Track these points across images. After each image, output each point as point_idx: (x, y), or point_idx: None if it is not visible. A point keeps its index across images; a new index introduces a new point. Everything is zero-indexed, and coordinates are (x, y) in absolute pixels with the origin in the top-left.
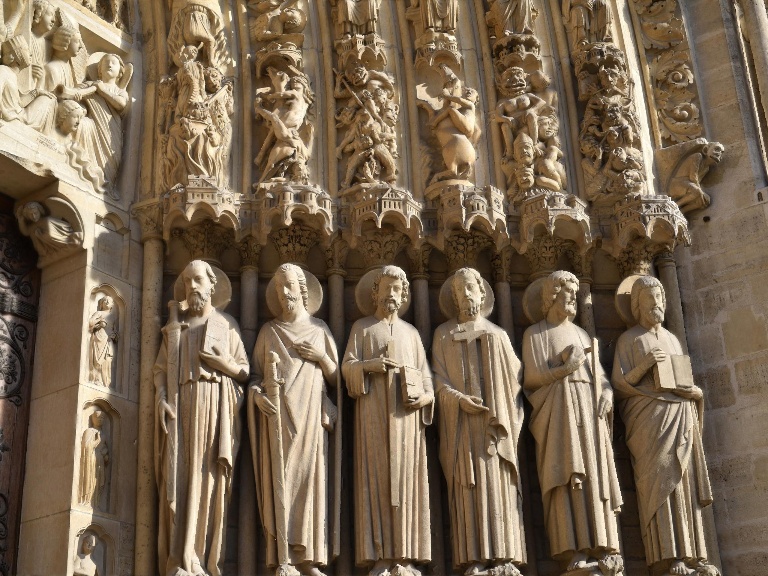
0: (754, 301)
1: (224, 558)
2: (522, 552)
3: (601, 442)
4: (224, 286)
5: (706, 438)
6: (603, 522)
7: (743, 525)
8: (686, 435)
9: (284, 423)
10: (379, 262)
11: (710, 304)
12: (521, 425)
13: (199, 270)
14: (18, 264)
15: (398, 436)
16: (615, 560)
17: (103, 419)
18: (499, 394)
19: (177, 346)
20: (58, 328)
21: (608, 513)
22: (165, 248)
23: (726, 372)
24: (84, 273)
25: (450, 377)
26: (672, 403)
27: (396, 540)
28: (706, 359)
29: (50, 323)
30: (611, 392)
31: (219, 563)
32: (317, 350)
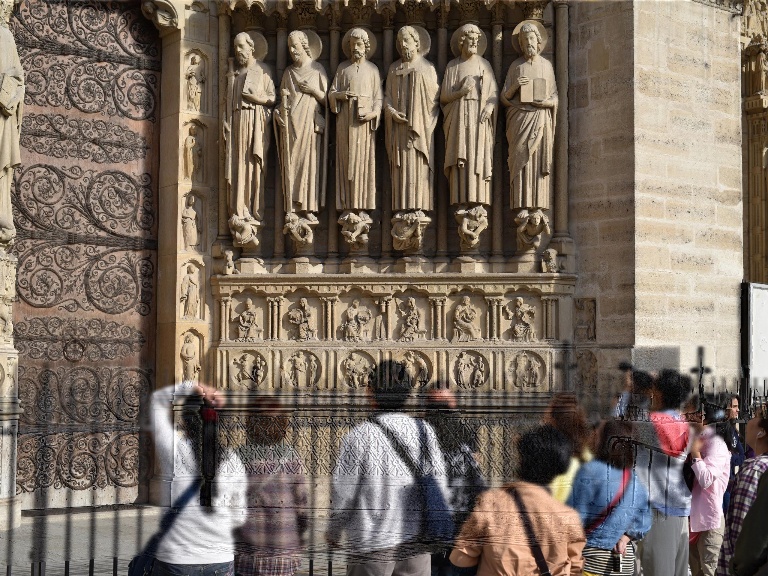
0: (606, 35)
1: (264, 207)
2: (430, 204)
3: (479, 138)
4: (263, 44)
5: (571, 127)
6: (475, 187)
7: (582, 184)
8: (536, 132)
9: (291, 132)
10: (359, 21)
11: (584, 35)
12: (433, 128)
13: (241, 40)
14: (147, 37)
15: (355, 138)
16: (477, 210)
17: (196, 130)
18: (415, 111)
19: (232, 87)
20: (170, 77)
21: (480, 182)
22: (231, 19)
23: (586, 84)
24: (180, 44)
25: (393, 99)
26: (530, 111)
27: (352, 199)
28: (577, 74)
29: (167, 73)
30: (493, 105)
31: (261, 210)
32: (310, 87)
